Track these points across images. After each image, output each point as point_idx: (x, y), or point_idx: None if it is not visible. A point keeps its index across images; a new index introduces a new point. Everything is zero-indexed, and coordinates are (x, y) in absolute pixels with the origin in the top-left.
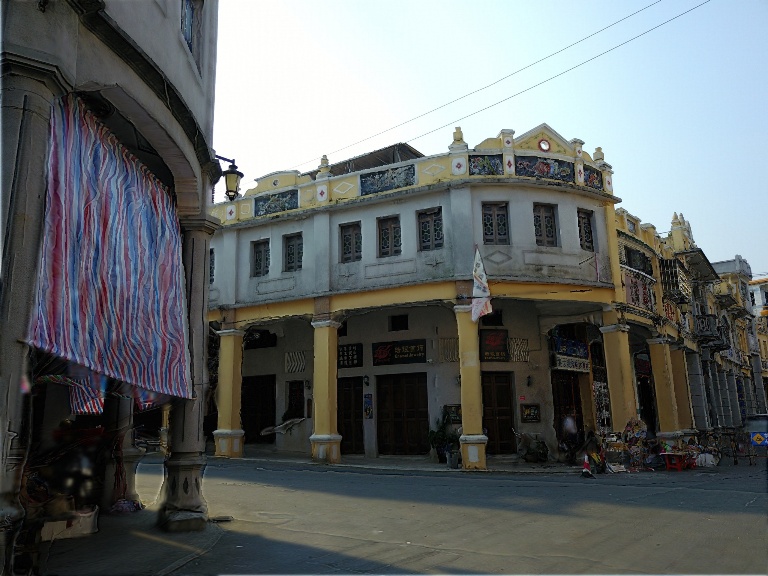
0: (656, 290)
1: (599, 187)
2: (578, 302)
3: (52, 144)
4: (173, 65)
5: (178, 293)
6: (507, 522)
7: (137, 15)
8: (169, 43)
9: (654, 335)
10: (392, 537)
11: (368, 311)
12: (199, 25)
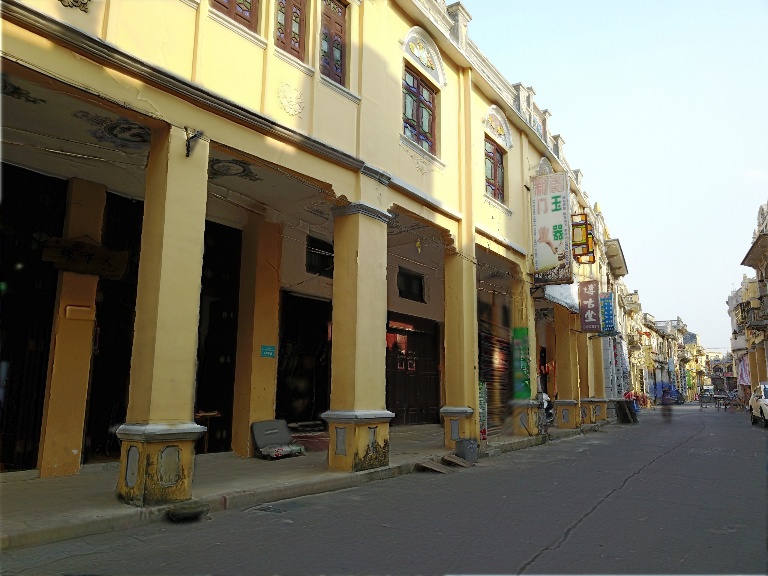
0: None
1: None
2: None
3: (739, 365)
4: None
5: None
6: None
7: None
8: None
9: None
10: None
11: None
12: None
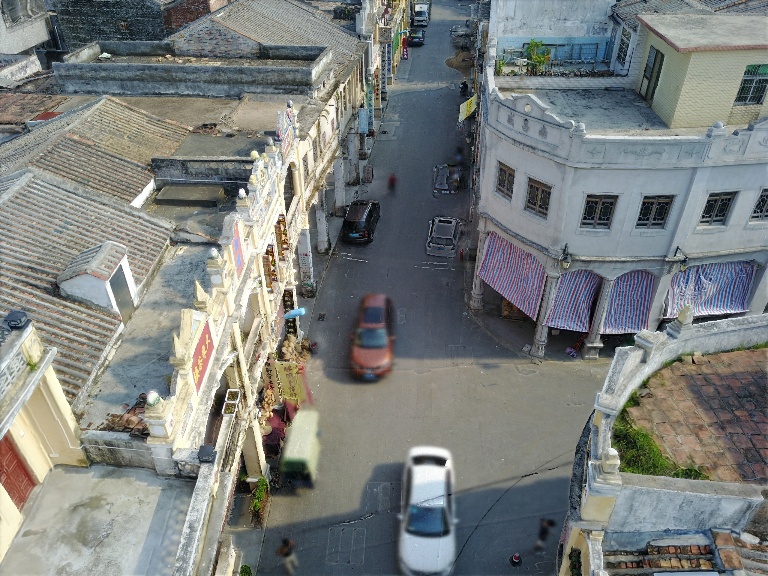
0: None
1: None
2: None
3: None
4: None
5: None
6: None
7: (501, 212)
8: None
9: None
10: (474, 369)
11: None
12: None
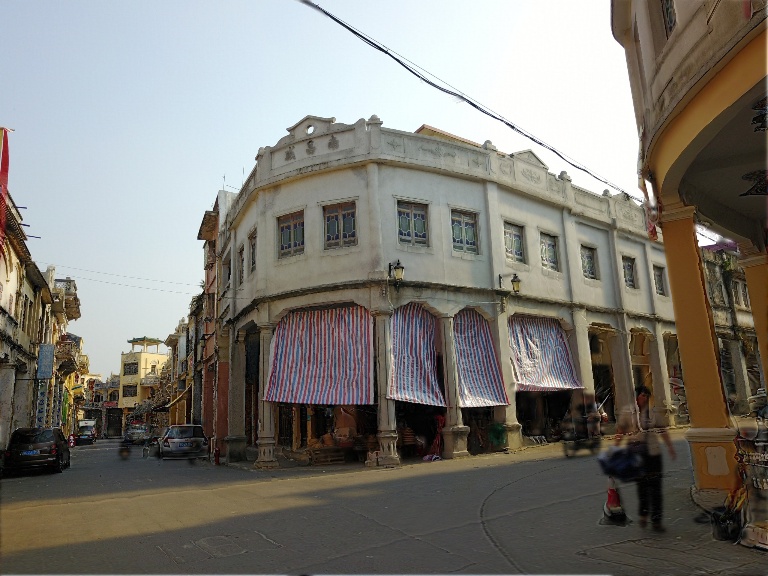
0: None
1: None
2: None
3: None
4: (316, 272)
5: (365, 354)
6: None
7: None
8: (311, 266)
9: None
10: None
11: (720, 242)
12: (356, 217)
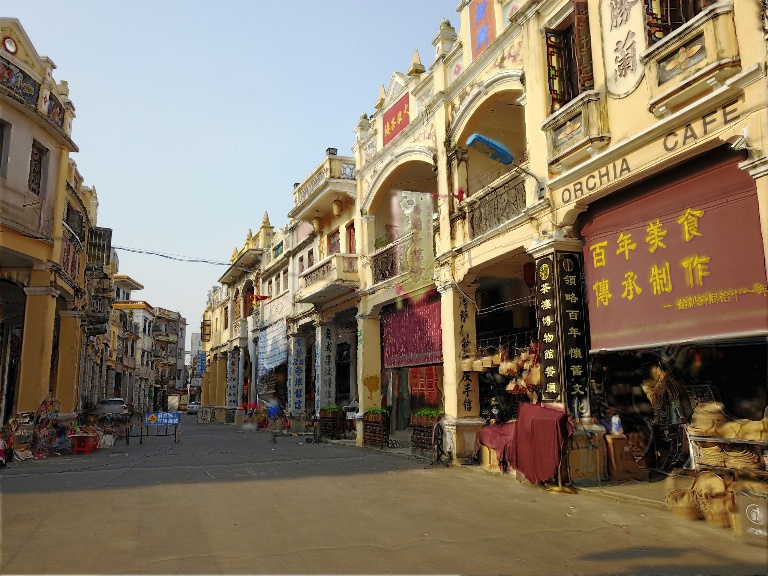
0: (81, 259)
1: (59, 126)
2: (9, 251)
3: None
4: None
5: None
6: (6, 534)
7: None
8: None
9: (69, 307)
10: None
11: None
12: None
